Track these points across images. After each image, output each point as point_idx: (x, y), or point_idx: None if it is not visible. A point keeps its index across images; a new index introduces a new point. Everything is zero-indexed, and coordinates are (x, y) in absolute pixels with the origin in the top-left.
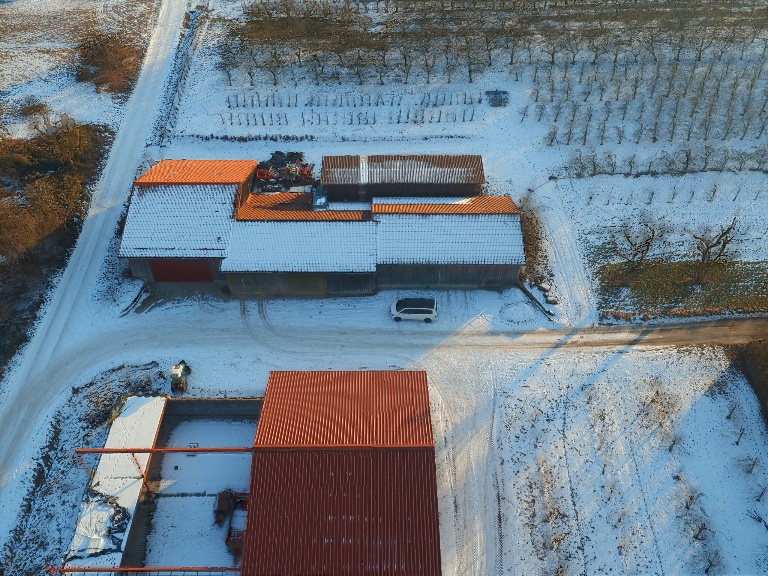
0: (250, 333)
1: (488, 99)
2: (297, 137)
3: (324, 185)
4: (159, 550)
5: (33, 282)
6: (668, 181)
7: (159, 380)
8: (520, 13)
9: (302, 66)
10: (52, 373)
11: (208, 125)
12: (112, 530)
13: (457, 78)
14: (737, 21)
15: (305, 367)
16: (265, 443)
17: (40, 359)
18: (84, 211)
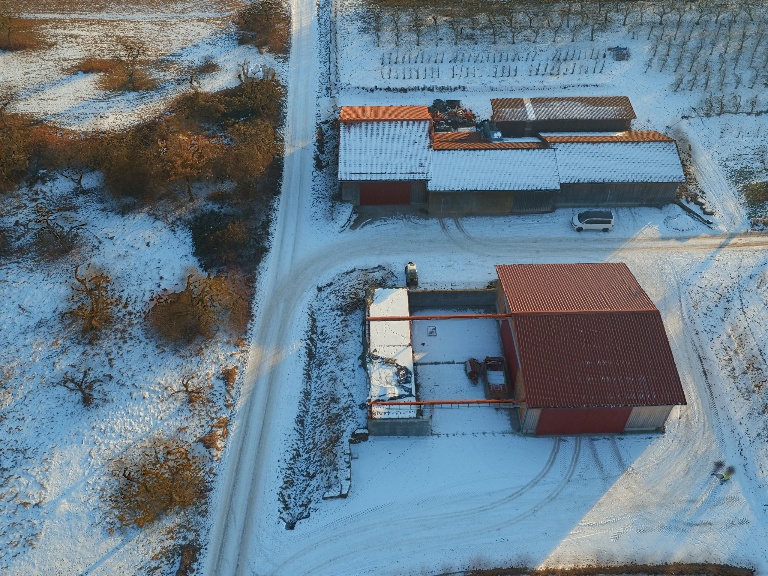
0: (455, 243)
1: (611, 54)
2: (451, 88)
3: (490, 125)
4: None
5: (257, 206)
6: None
7: (392, 278)
8: None
9: (438, 29)
10: (296, 276)
11: (369, 79)
12: (400, 382)
13: (579, 37)
14: None
15: None
16: (520, 310)
17: (282, 265)
18: (281, 150)
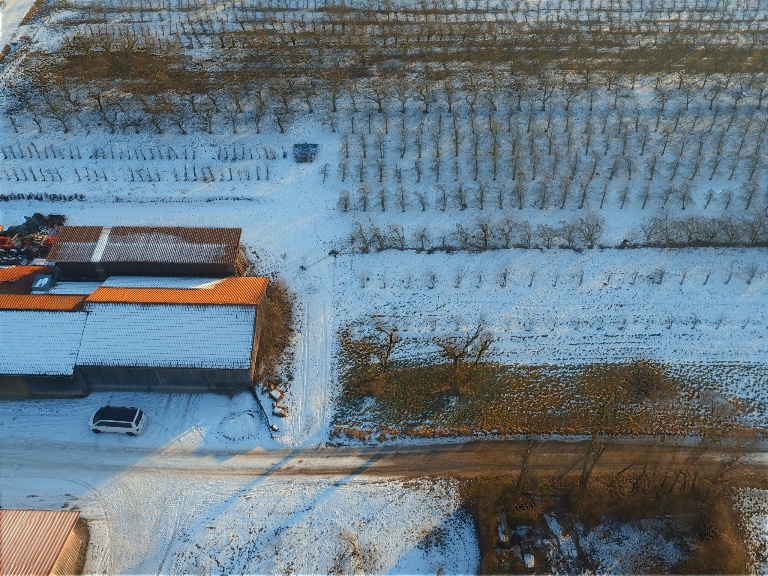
0: None
1: (294, 153)
2: (65, 196)
3: None
4: None
5: None
6: (463, 259)
7: None
8: (360, 52)
9: (103, 110)
10: None
11: None
12: None
13: (269, 127)
14: (600, 64)
15: None
16: None
17: None
18: None
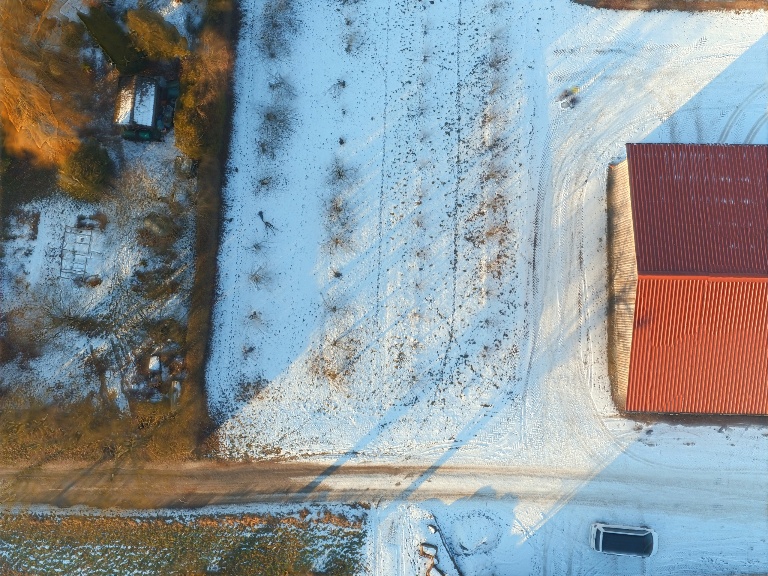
0: None
1: None
2: None
3: None
4: None
5: None
6: None
7: None
8: None
9: None
10: None
11: None
12: None
13: None
14: None
15: (765, 449)
16: None
17: None
18: None
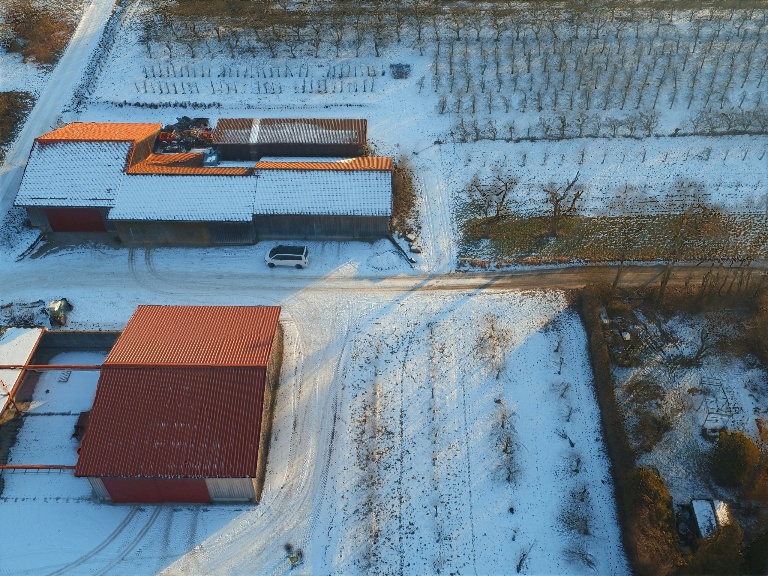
0: (134, 276)
1: (391, 72)
2: (205, 104)
3: None
4: (19, 459)
5: None
6: (545, 146)
7: (41, 315)
8: None
9: (221, 41)
10: None
11: (123, 93)
12: None
13: (365, 53)
14: (641, 3)
15: None
16: (114, 361)
17: None
18: None
